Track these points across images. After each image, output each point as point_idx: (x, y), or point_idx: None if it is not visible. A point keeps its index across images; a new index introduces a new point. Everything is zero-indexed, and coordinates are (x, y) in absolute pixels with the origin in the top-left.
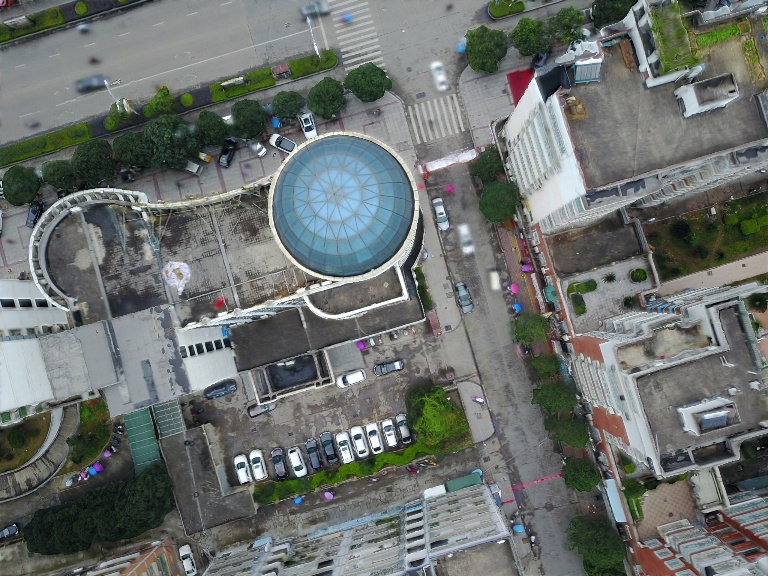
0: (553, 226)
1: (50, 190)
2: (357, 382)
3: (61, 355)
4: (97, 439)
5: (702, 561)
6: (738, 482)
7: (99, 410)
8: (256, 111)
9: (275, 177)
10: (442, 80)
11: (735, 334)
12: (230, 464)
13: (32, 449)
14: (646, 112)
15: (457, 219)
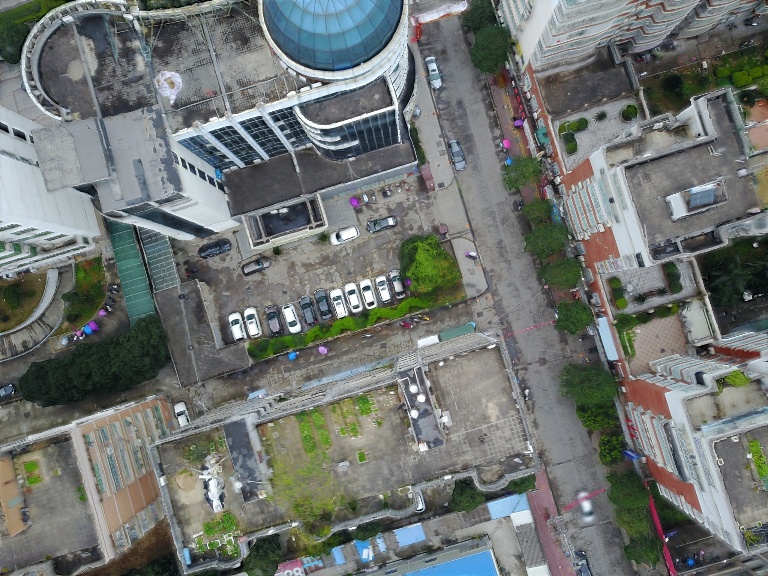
0: (543, 50)
1: None
2: (351, 238)
3: (53, 148)
4: (92, 295)
5: (692, 371)
6: (730, 329)
7: (94, 271)
8: None
9: None
10: None
11: (723, 124)
12: (225, 323)
13: (28, 310)
14: None
15: (450, 78)
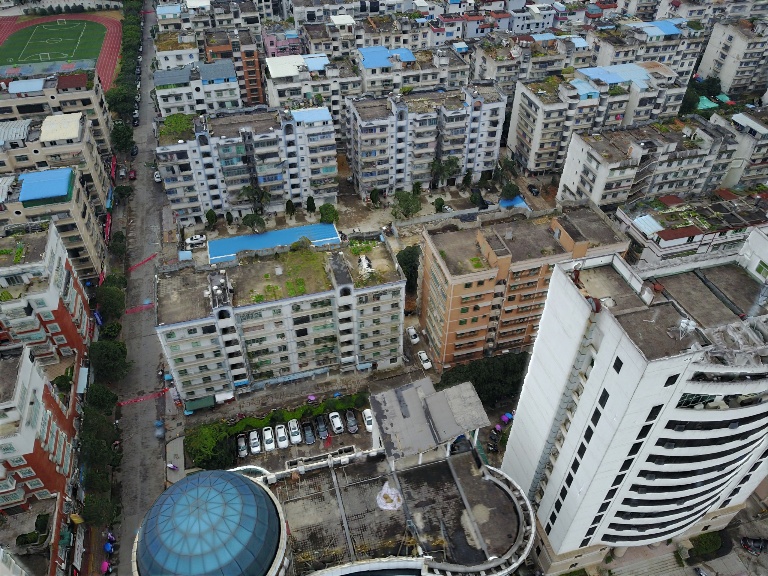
0: (26, 573)
1: None
2: None
3: (471, 412)
4: (506, 435)
5: (32, 322)
6: None
7: None
8: None
9: (273, 570)
10: None
11: None
12: None
13: None
14: None
15: None
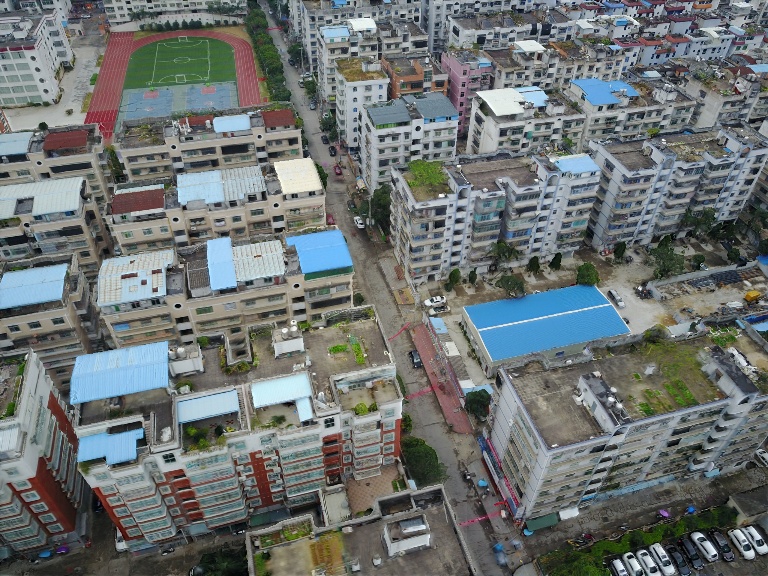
0: None
1: None
2: None
3: None
4: None
5: None
6: None
7: None
8: None
9: None
10: None
11: None
12: None
13: None
14: None
15: None
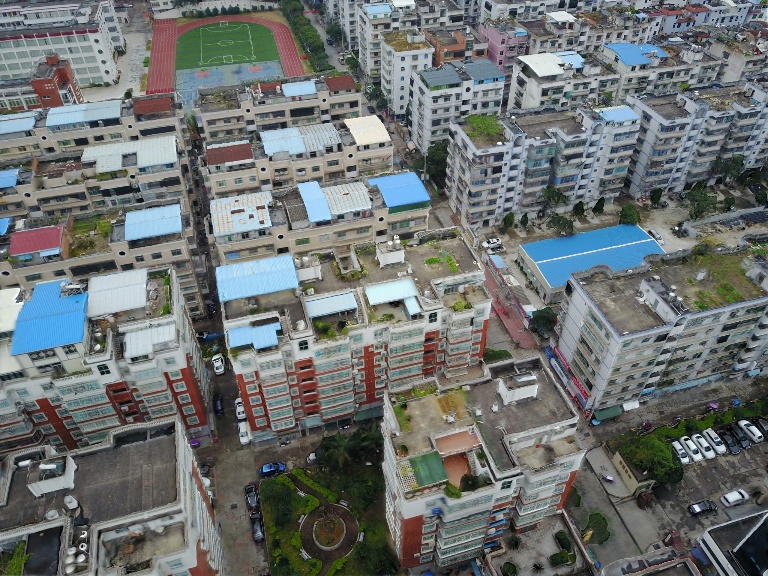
0: None
1: None
2: None
3: None
4: None
5: None
6: None
7: None
8: None
9: None
10: None
11: (497, 451)
12: None
13: None
14: None
15: None
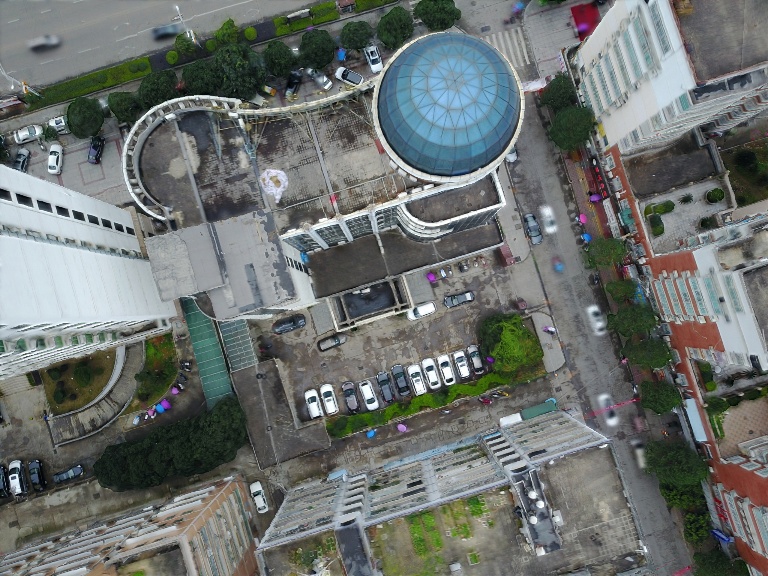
0: (639, 140)
1: (111, 126)
2: (428, 314)
3: (167, 256)
4: (166, 375)
5: None
6: None
7: (165, 348)
8: (327, 39)
9: (380, 77)
10: (507, 13)
11: None
12: (300, 400)
13: (96, 388)
14: (752, 7)
15: (524, 151)
